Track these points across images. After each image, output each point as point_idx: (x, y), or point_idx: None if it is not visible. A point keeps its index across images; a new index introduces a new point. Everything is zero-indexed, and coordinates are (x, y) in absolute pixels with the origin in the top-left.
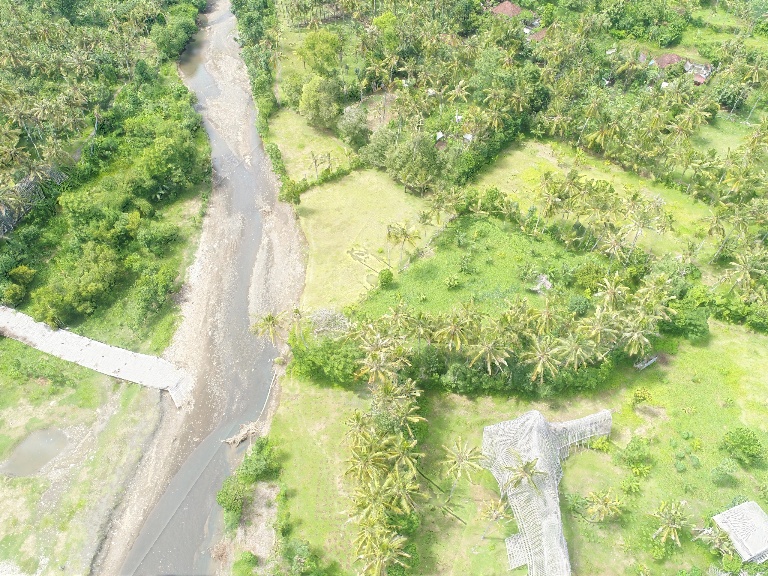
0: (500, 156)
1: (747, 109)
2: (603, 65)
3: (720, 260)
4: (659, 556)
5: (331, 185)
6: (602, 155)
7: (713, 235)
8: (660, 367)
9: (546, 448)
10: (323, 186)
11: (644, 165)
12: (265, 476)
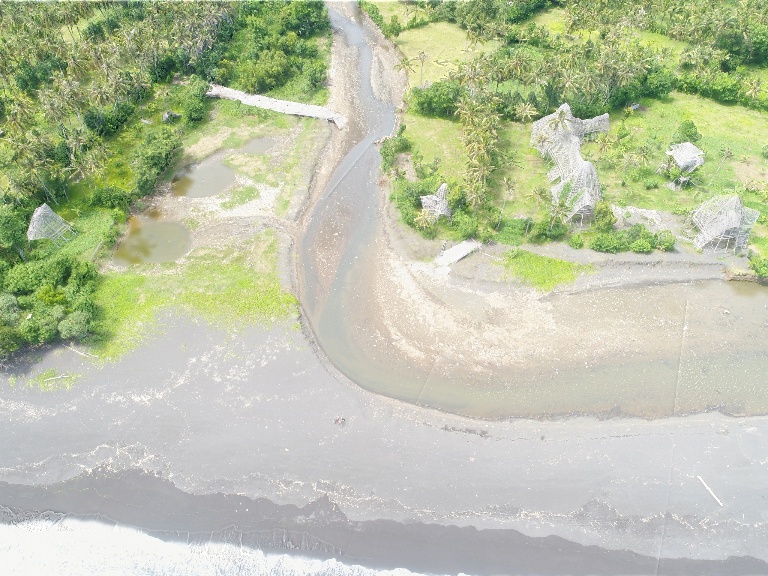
0: (534, 16)
1: None
2: None
3: (684, 66)
4: (635, 173)
5: (416, 30)
6: None
7: None
8: (641, 112)
9: (571, 123)
10: (411, 30)
11: None
12: (403, 150)
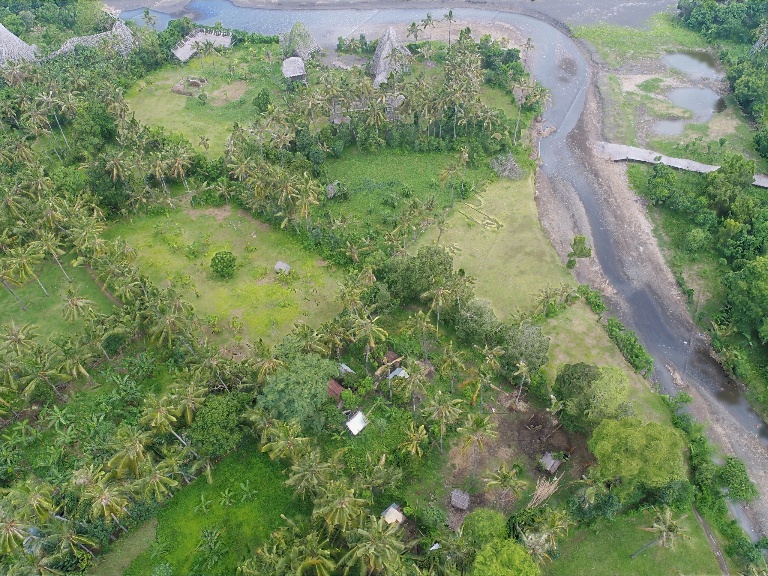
0: None
1: None
2: (0, 560)
3: None
4: None
5: None
6: None
7: (144, 234)
8: None
9: None
10: None
11: None
12: None
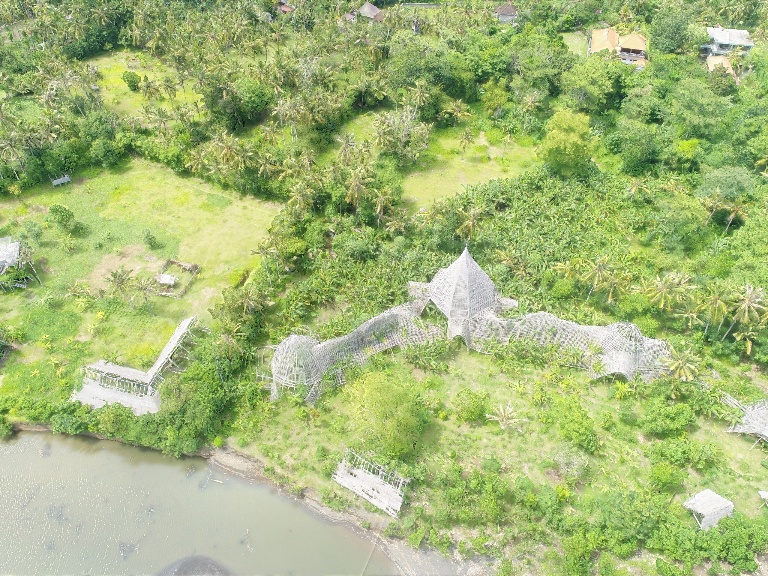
0: (88, 61)
1: None
2: None
3: None
4: None
5: None
6: (166, 60)
7: None
8: (73, 185)
9: None
10: None
11: (182, 64)
12: None
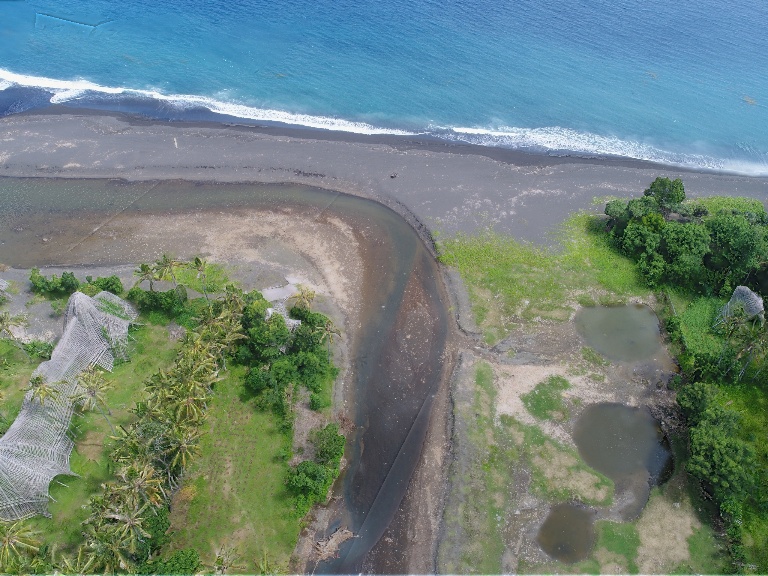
0: None
1: None
2: None
3: None
4: None
5: None
6: None
7: None
8: None
9: None
10: None
11: None
12: None
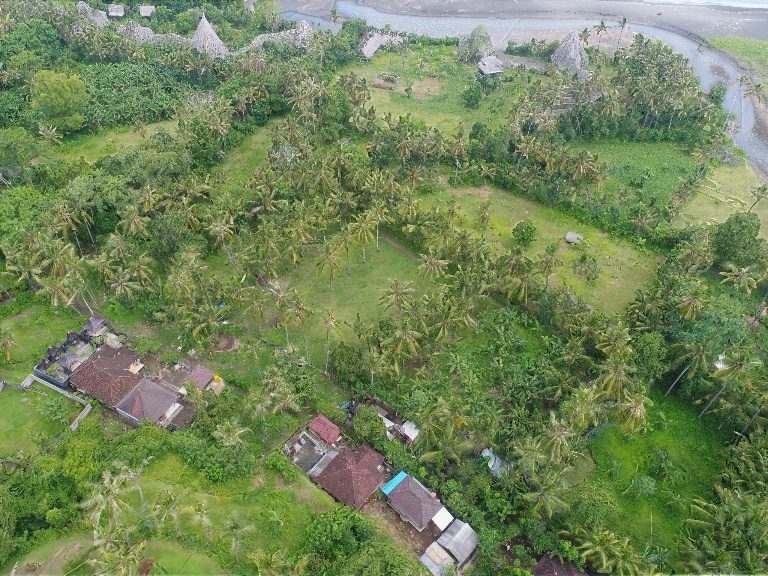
0: None
1: (263, 385)
2: None
3: None
4: None
5: None
6: None
7: None
8: None
9: None
10: None
11: None
12: None
